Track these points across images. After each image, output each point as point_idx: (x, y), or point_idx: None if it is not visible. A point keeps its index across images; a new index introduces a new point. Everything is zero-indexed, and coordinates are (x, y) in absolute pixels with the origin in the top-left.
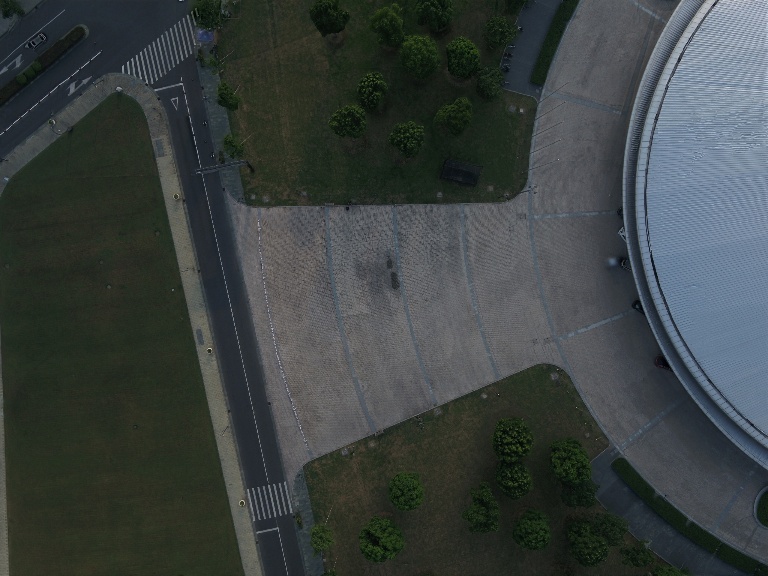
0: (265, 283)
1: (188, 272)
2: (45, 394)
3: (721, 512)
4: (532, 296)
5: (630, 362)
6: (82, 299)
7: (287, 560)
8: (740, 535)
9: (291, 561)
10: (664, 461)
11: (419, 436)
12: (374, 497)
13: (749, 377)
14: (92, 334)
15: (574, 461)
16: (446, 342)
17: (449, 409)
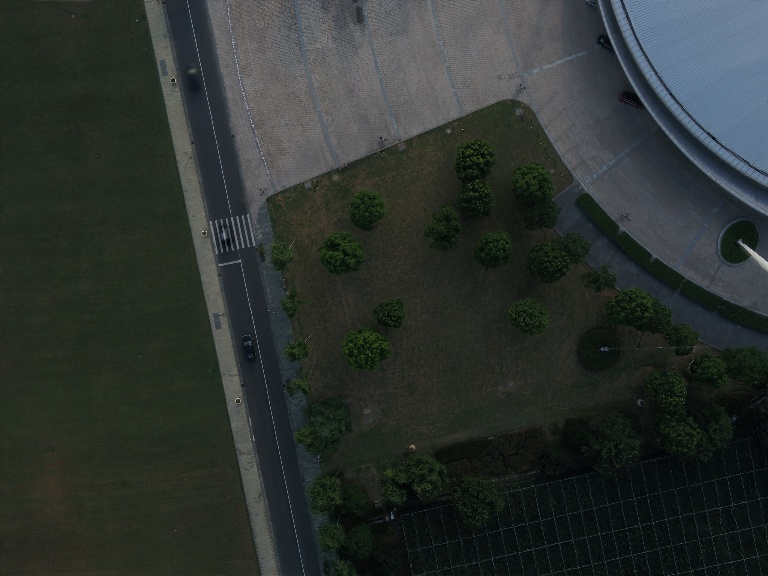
0: (230, 15)
1: (152, 3)
2: (7, 121)
3: (685, 249)
4: (497, 32)
5: (595, 98)
6: (45, 27)
7: (249, 293)
8: (704, 273)
9: (253, 294)
10: (628, 198)
11: (383, 170)
12: (337, 229)
13: (710, 85)
14: (55, 62)
15: (535, 173)
16: (411, 77)
17: (413, 144)
